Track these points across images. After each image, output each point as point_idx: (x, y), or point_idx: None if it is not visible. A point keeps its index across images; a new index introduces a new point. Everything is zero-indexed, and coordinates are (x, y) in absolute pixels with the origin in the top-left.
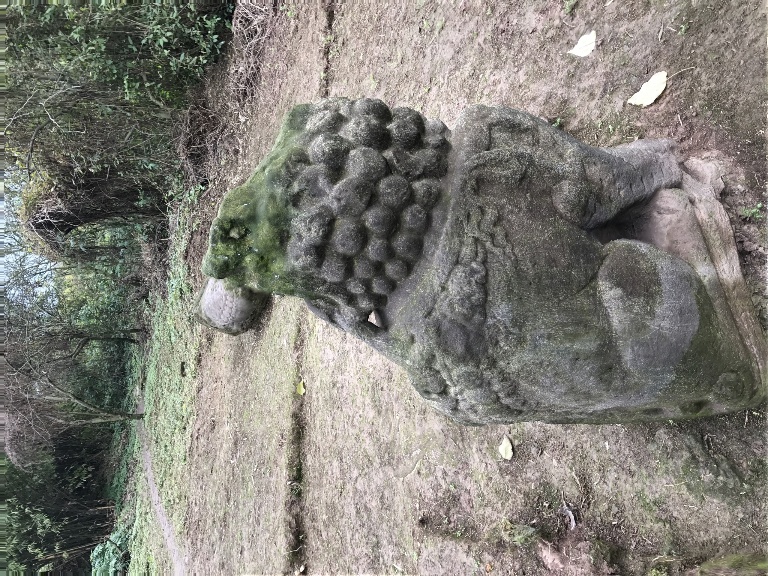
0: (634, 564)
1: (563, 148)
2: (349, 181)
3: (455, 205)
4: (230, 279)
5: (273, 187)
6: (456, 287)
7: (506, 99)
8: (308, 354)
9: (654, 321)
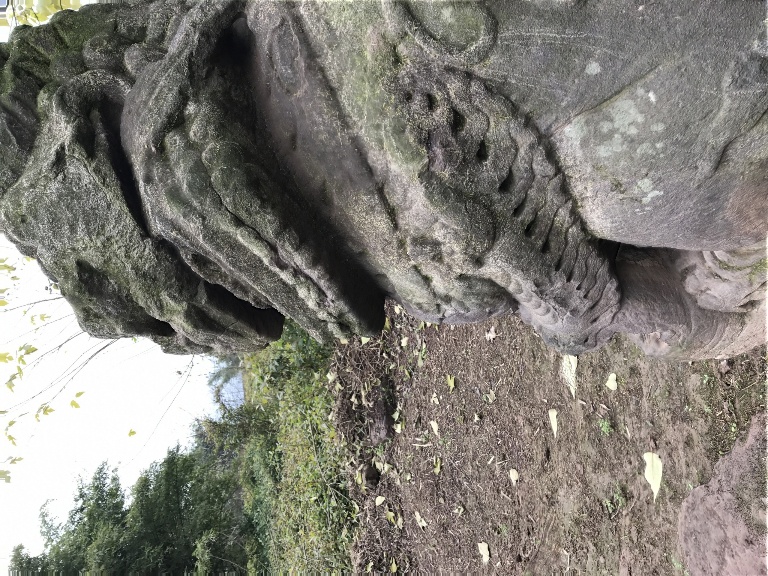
0: None
1: None
2: None
3: None
4: None
5: None
6: None
7: None
8: None
9: None
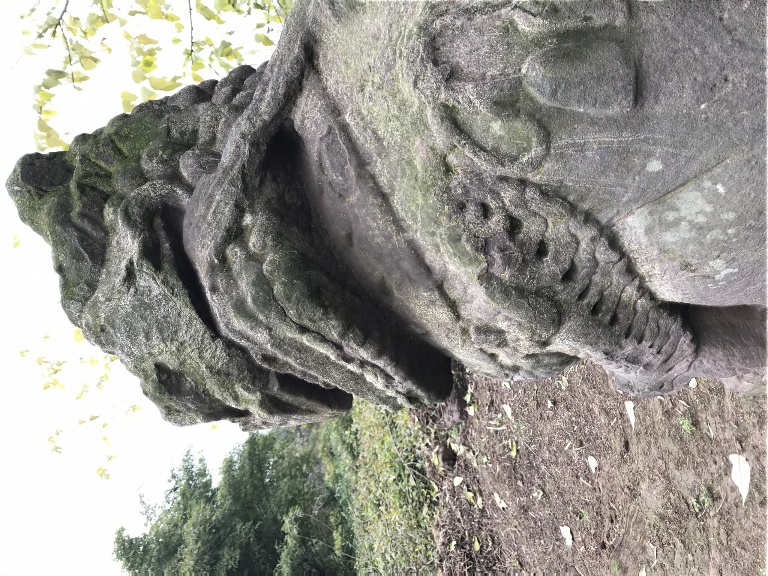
0: None
1: None
2: None
3: None
4: (46, 203)
5: None
6: None
7: None
8: None
9: None
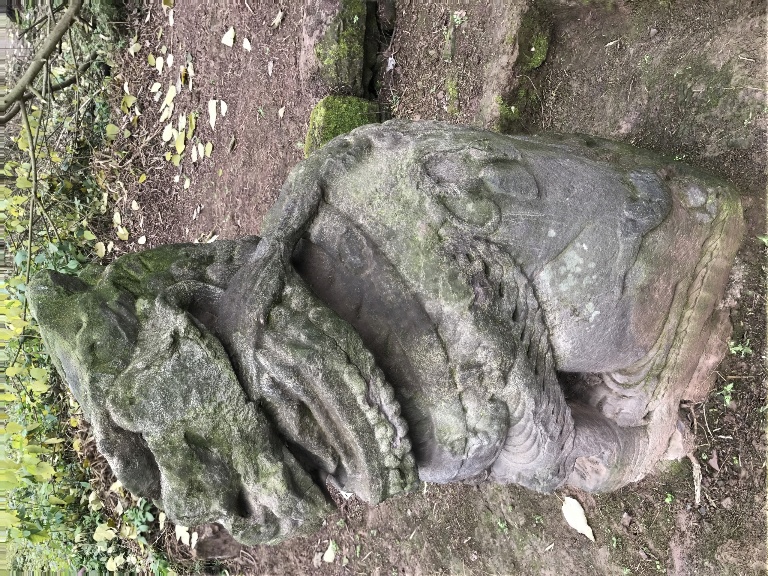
0: None
1: None
2: None
3: None
4: (77, 297)
5: None
6: None
7: None
8: None
9: None
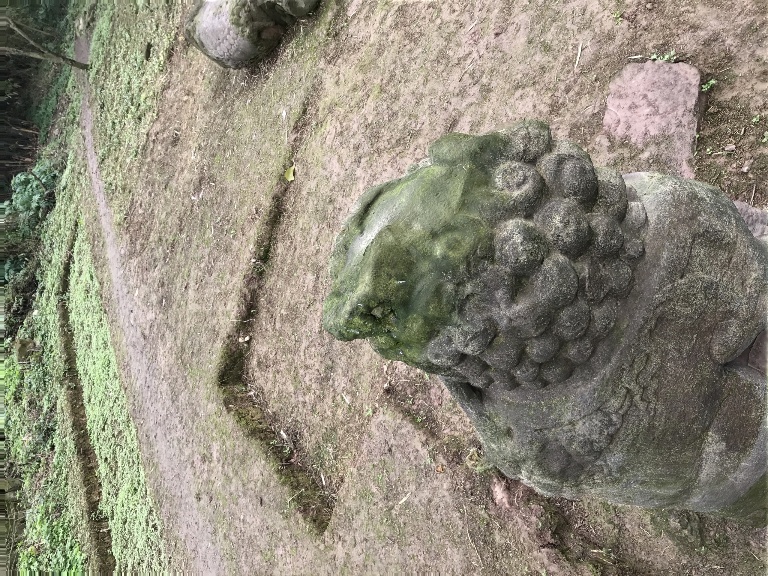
0: (574, 543)
1: (749, 270)
2: (533, 308)
3: (625, 348)
4: None
5: (441, 278)
6: (585, 430)
7: (660, 1)
8: (309, 146)
9: (734, 474)
